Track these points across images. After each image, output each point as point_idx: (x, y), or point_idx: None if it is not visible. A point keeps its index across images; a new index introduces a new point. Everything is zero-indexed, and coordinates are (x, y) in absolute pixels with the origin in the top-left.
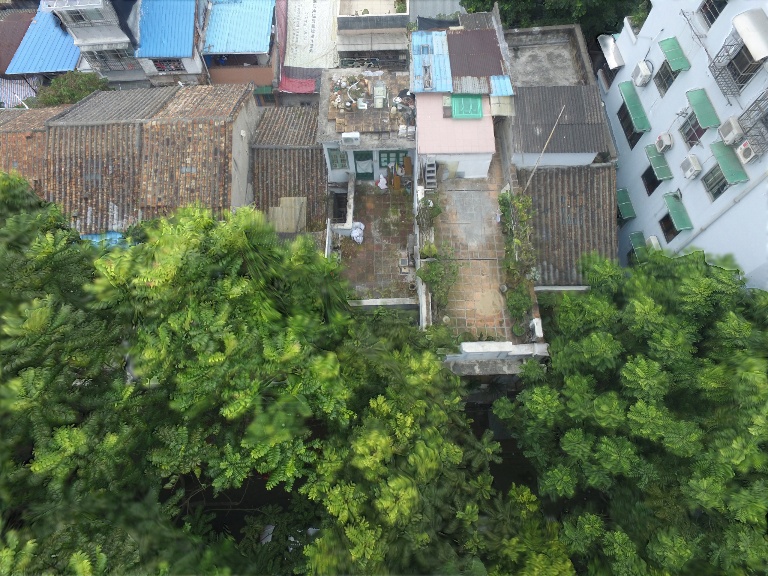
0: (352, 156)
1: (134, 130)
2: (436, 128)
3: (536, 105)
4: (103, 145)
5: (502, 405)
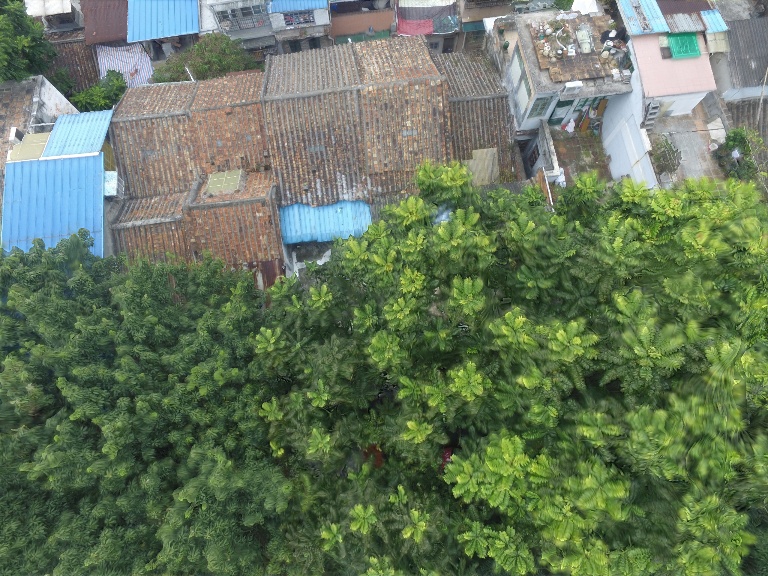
0: (555, 103)
1: (351, 97)
2: (658, 70)
3: (748, 38)
4: (322, 116)
5: None
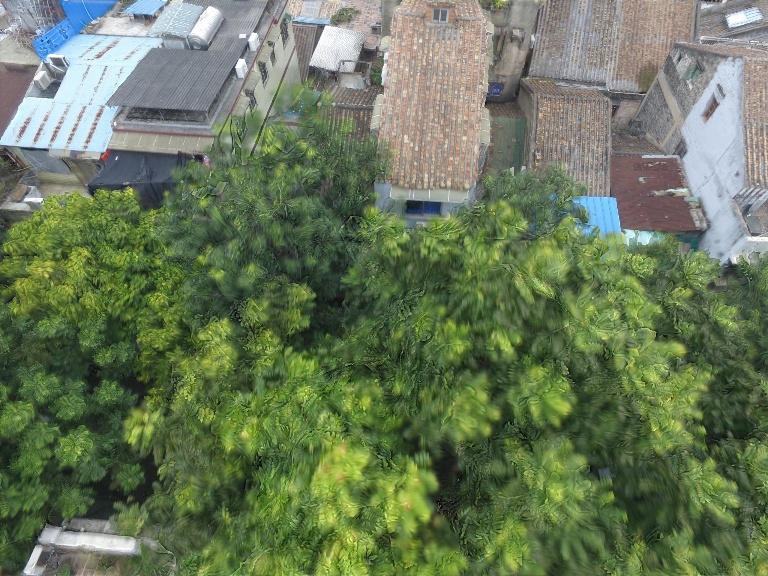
0: None
1: None
2: None
3: None
4: None
5: (130, 479)
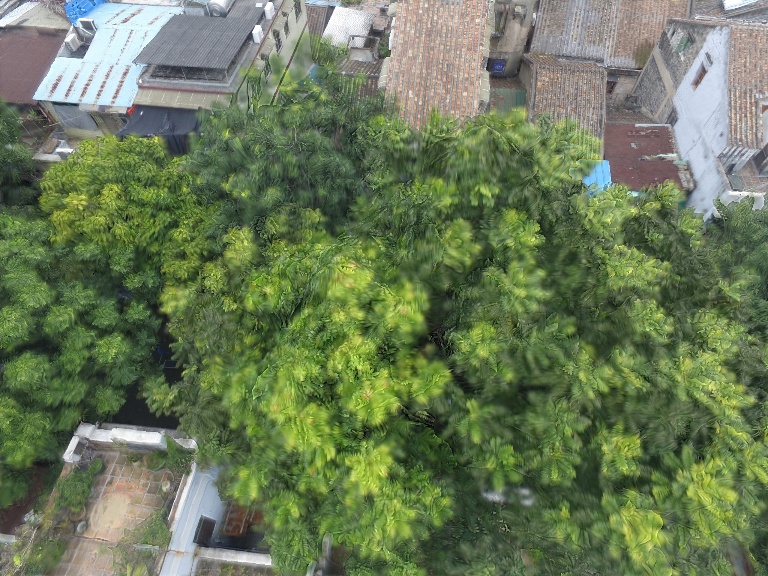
0: None
1: None
2: None
3: None
4: None
5: (155, 390)
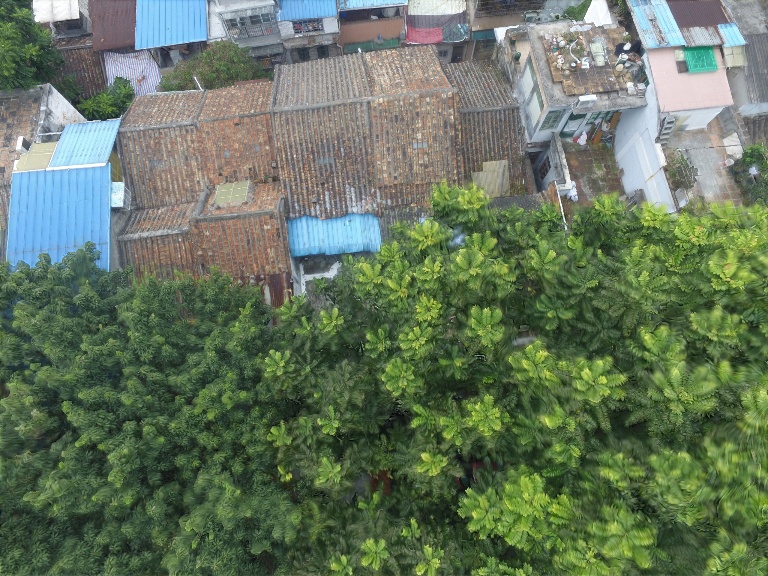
0: (567, 116)
1: (361, 109)
2: (674, 84)
3: (766, 53)
4: (332, 127)
5: None
